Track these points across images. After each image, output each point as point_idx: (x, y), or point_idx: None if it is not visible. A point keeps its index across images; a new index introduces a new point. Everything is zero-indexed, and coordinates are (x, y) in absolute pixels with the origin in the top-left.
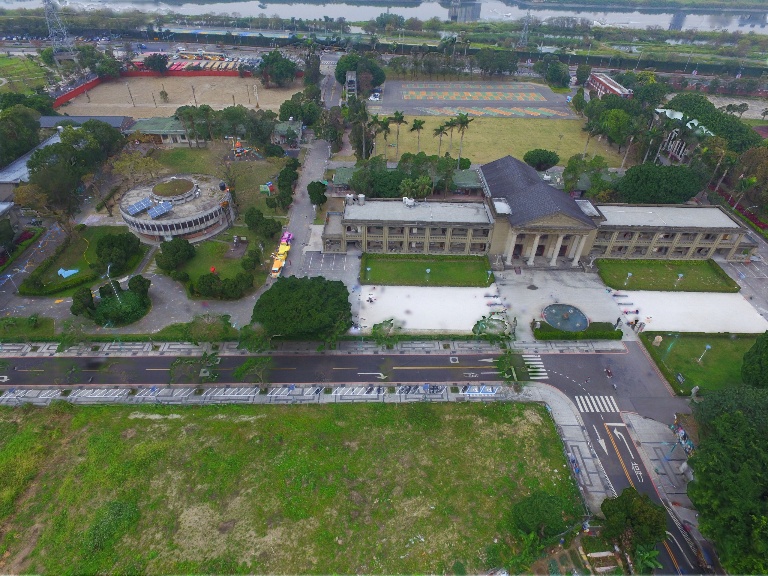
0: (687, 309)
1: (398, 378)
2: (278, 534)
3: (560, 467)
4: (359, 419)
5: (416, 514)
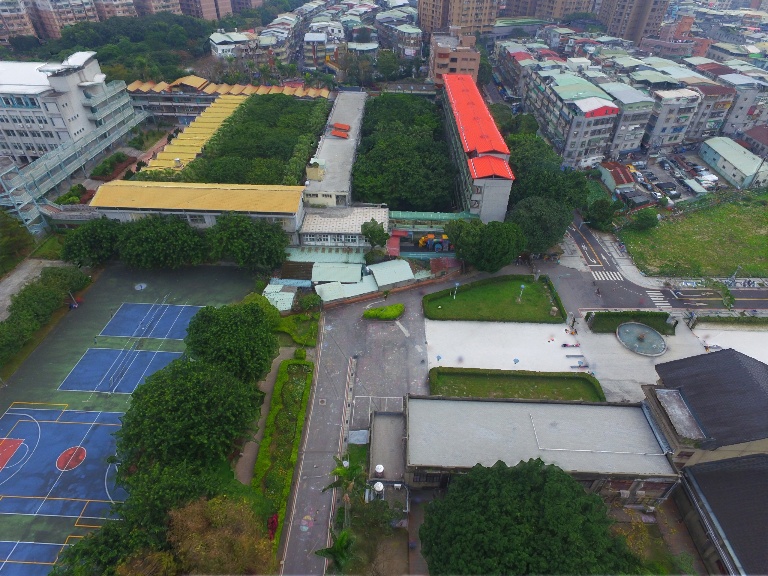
0: (505, 351)
1: (763, 292)
2: (762, 232)
3: (630, 249)
4: (767, 267)
5: (700, 236)
